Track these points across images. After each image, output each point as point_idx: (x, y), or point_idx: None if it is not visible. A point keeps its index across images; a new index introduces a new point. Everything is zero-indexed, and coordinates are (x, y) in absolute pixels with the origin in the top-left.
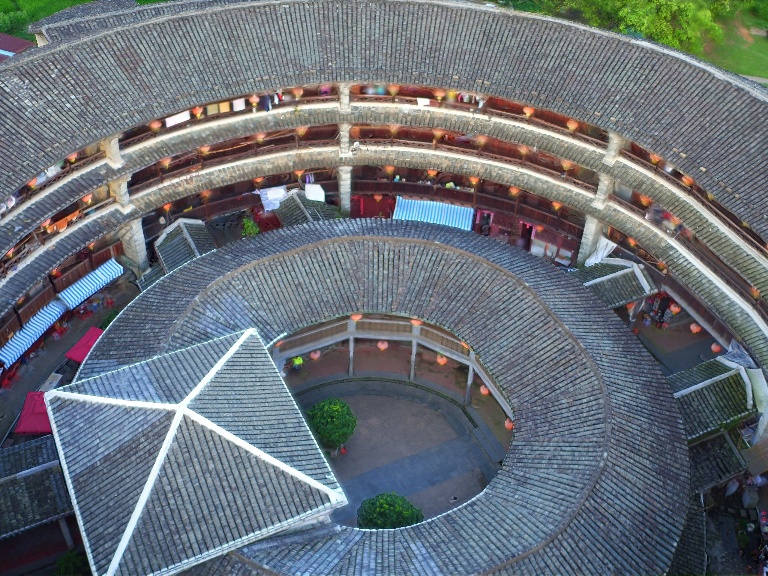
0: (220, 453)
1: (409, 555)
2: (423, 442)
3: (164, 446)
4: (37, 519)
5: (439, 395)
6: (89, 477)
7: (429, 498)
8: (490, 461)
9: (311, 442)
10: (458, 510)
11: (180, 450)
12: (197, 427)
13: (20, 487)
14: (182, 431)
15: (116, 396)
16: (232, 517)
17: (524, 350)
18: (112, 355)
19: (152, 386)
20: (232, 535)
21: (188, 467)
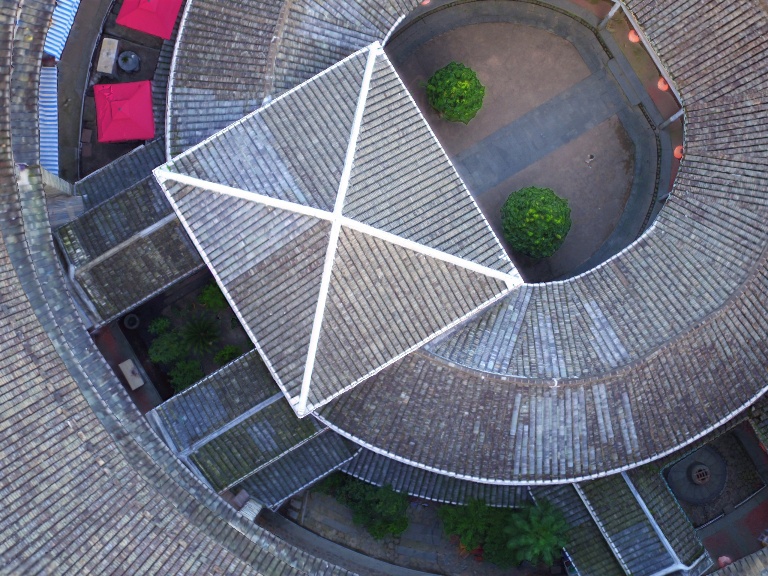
0: (387, 259)
1: (586, 321)
2: (552, 86)
3: (328, 266)
4: (176, 274)
5: (566, 14)
6: (246, 288)
7: (564, 159)
8: (628, 104)
9: (475, 213)
10: (628, 252)
11: (344, 264)
12: (358, 236)
13: (148, 246)
14: (342, 243)
15: (246, 184)
16: (410, 322)
17: (703, 23)
18: (204, 83)
19: (284, 166)
20: (413, 339)
21: (356, 280)
